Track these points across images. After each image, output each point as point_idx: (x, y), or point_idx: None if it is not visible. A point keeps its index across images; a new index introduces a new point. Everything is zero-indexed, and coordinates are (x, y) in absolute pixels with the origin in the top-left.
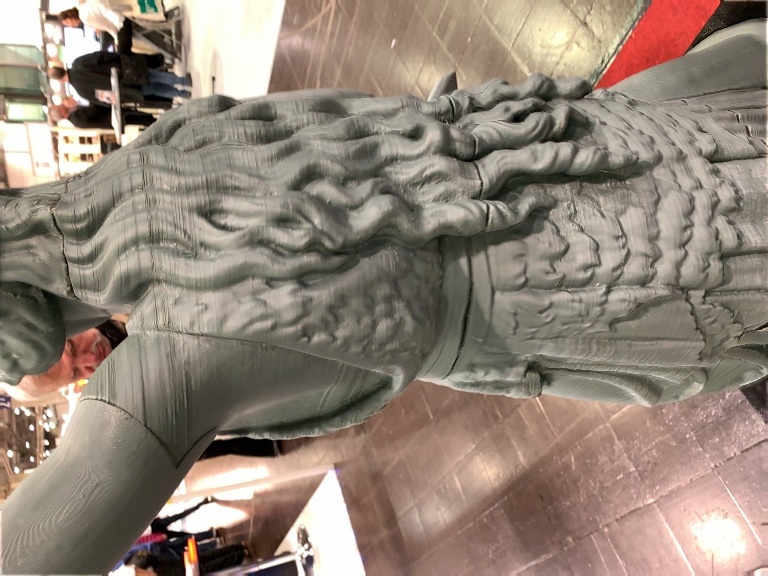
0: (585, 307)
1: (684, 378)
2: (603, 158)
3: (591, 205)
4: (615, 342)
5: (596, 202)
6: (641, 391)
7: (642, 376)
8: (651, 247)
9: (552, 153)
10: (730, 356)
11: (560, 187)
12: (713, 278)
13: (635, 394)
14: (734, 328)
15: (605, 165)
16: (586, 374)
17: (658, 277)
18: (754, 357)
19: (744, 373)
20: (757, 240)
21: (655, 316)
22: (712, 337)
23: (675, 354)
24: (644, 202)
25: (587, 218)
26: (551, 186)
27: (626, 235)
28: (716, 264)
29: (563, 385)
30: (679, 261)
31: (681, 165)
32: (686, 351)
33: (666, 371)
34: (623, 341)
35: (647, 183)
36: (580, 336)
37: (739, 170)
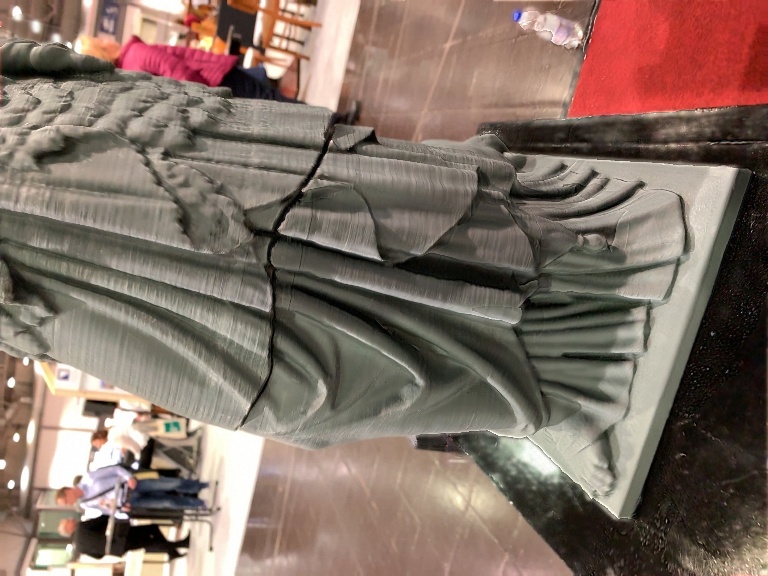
0: (2, 135)
1: (258, 338)
2: (61, 50)
3: (50, 84)
4: (53, 187)
5: (59, 86)
6: (213, 363)
7: (208, 339)
8: (95, 103)
9: (9, 43)
10: (314, 313)
11: (30, 80)
12: (171, 136)
13: (214, 376)
14: (221, 201)
15: (69, 60)
16: (96, 297)
17: (97, 123)
18: (362, 329)
19: (400, 390)
20: (240, 127)
21: (98, 161)
22: (198, 212)
23: (141, 216)
24: (108, 87)
25: (41, 90)
26: (23, 80)
27: (74, 98)
28: (176, 128)
29: (83, 326)
30: (126, 116)
31: (172, 85)
32: (154, 213)
33: (215, 312)
34: (64, 188)
35: (122, 83)
36: (7, 175)
37: (246, 102)
